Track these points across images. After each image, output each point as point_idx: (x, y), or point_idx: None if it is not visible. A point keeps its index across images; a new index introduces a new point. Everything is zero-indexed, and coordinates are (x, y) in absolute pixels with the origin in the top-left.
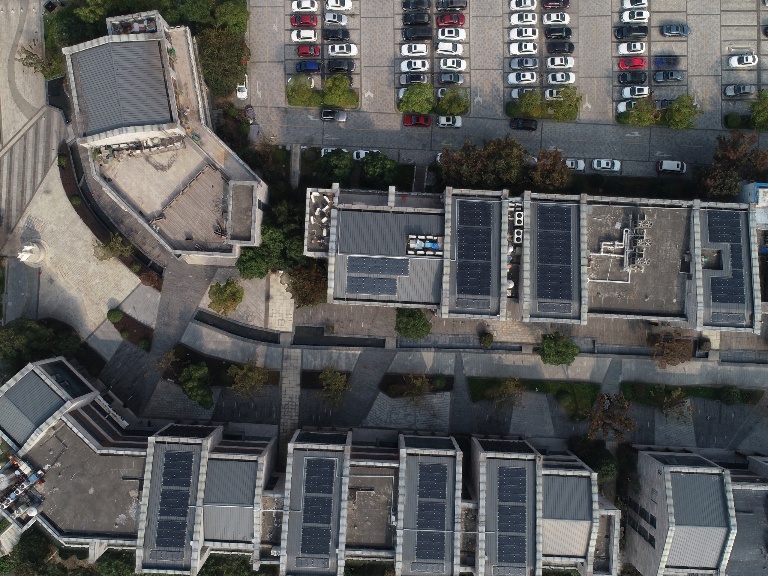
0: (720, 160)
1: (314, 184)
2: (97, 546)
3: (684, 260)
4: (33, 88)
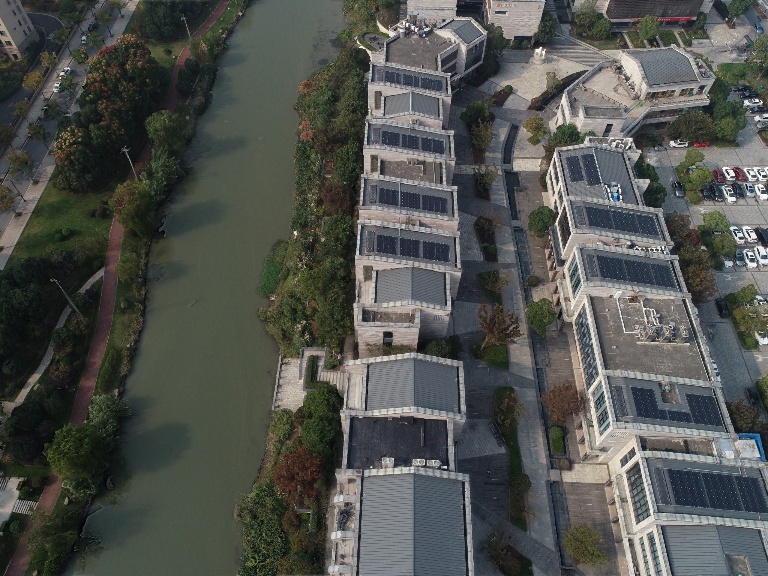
0: (765, 425)
1: None
2: (379, 57)
3: None
4: None
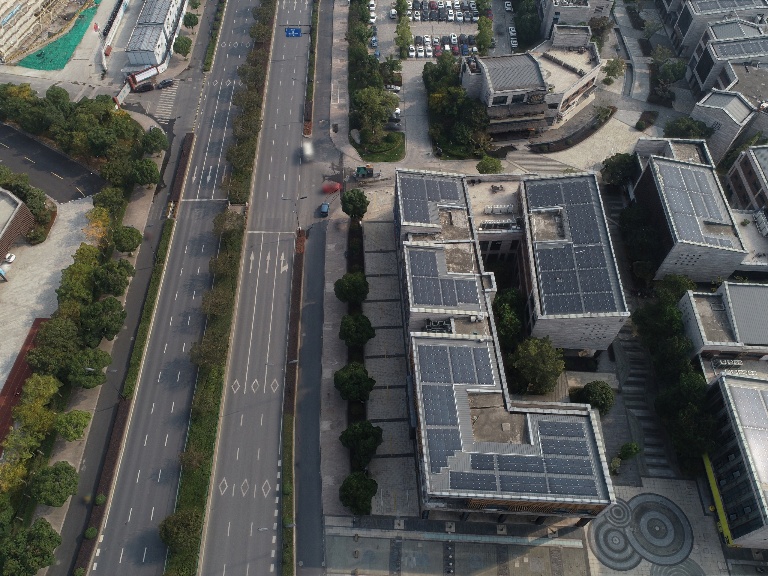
0: None
1: (537, 40)
2: None
3: None
4: None
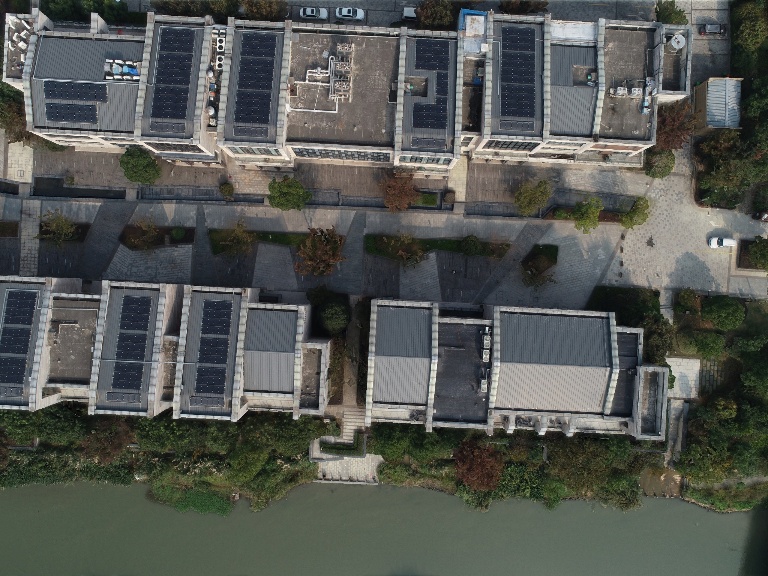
0: None
1: None
2: None
3: (392, 89)
4: None
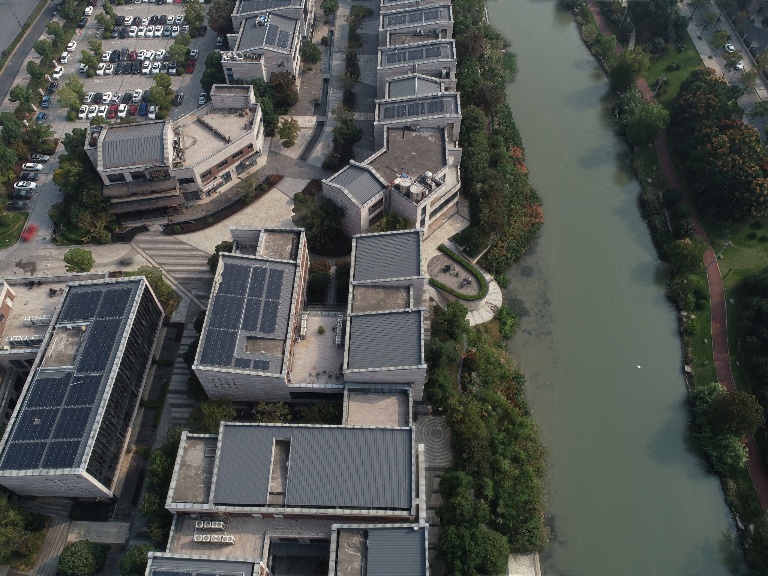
0: None
1: None
2: None
3: None
4: (114, 252)
